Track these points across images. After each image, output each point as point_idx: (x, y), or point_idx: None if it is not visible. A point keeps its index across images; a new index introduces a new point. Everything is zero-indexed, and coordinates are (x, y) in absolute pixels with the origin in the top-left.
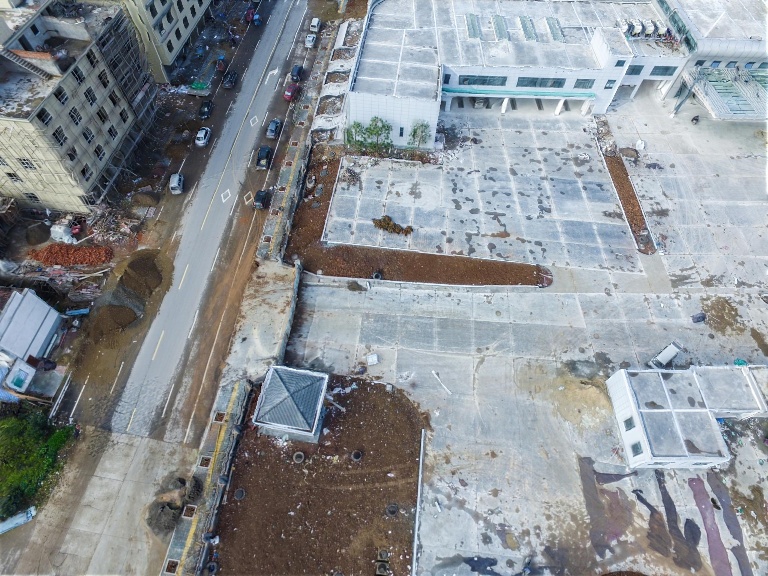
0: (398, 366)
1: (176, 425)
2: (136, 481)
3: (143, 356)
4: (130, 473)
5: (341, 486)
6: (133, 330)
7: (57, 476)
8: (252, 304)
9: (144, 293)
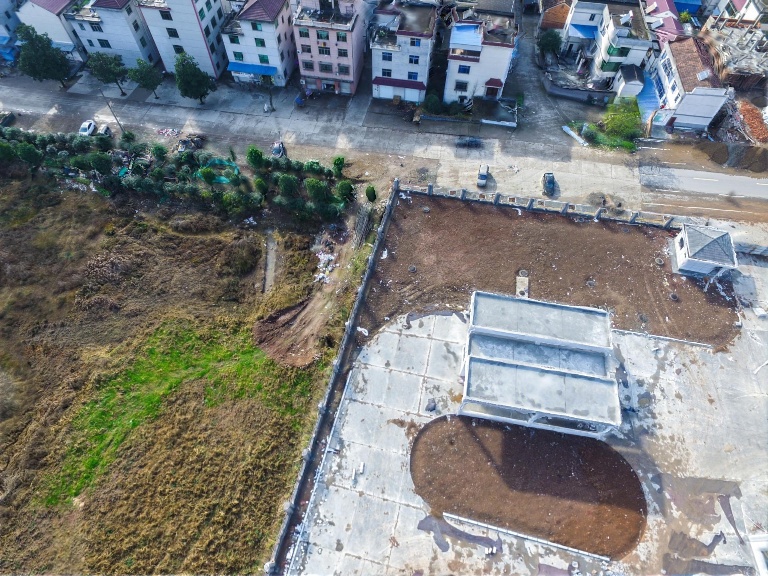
0: (762, 332)
1: (653, 197)
2: (614, 183)
3: (695, 173)
4: (617, 180)
5: (649, 286)
6: (711, 164)
7: (607, 149)
8: (767, 229)
9: (744, 164)
